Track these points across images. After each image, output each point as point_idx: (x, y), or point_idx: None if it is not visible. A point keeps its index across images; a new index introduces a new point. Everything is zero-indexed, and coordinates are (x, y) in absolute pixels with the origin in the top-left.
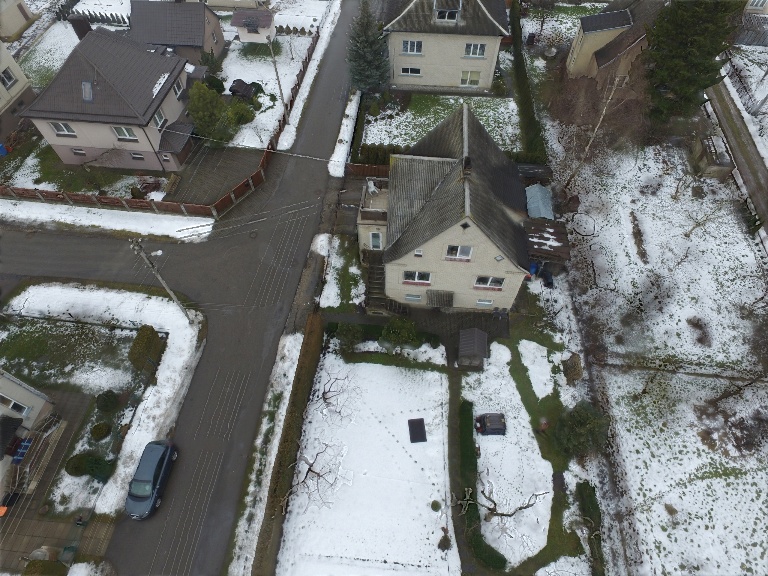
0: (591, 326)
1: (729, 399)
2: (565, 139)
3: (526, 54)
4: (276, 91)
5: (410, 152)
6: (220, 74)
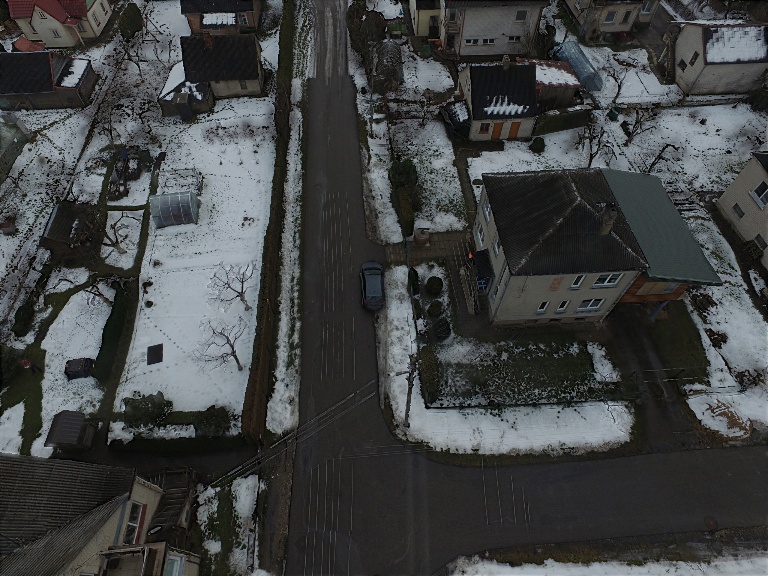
0: None
1: None
2: None
3: None
4: None
5: None
6: None
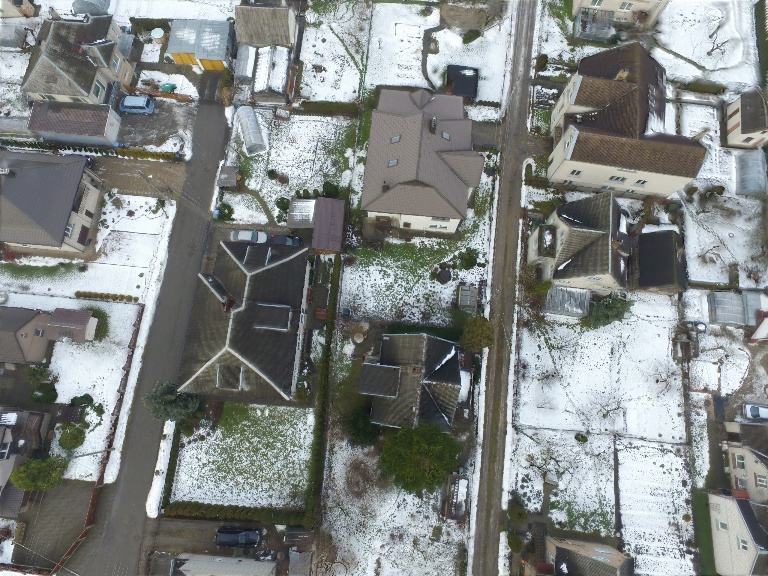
0: None
1: None
2: (347, 466)
3: (339, 333)
4: (103, 397)
5: None
6: (51, 371)
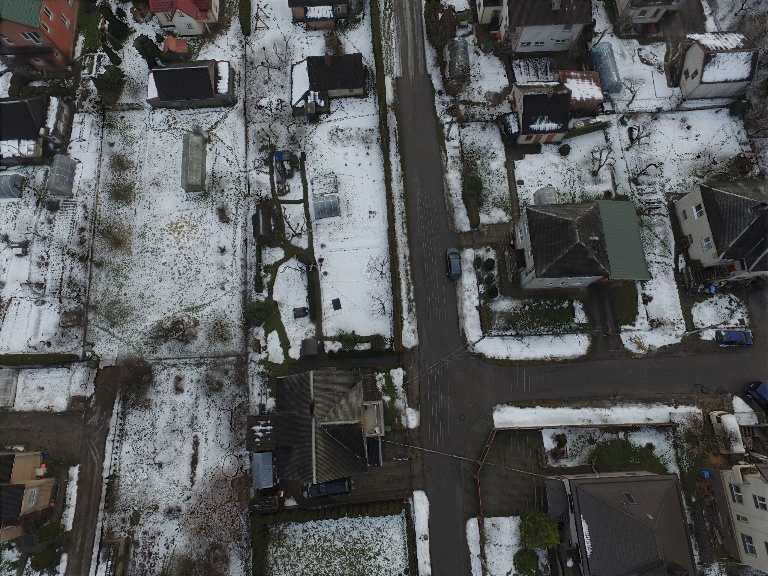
0: (241, 380)
1: (177, 346)
2: (229, 575)
3: None
4: None
5: (355, 468)
6: None
